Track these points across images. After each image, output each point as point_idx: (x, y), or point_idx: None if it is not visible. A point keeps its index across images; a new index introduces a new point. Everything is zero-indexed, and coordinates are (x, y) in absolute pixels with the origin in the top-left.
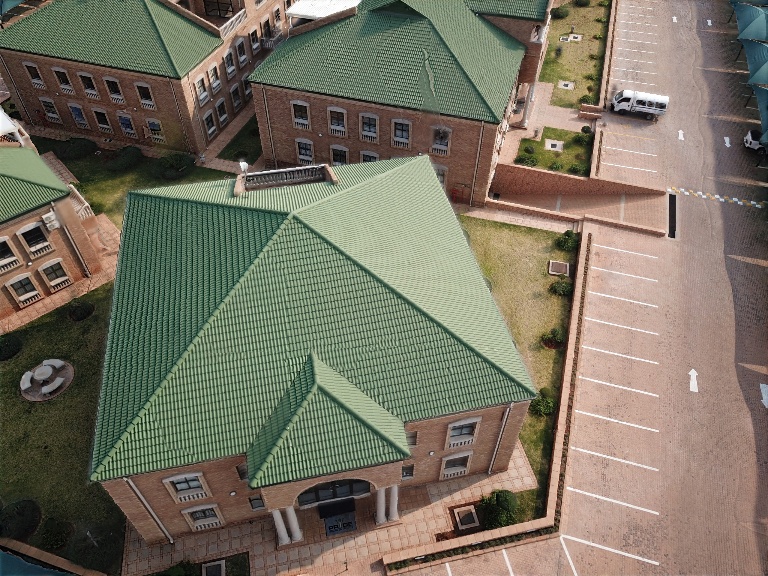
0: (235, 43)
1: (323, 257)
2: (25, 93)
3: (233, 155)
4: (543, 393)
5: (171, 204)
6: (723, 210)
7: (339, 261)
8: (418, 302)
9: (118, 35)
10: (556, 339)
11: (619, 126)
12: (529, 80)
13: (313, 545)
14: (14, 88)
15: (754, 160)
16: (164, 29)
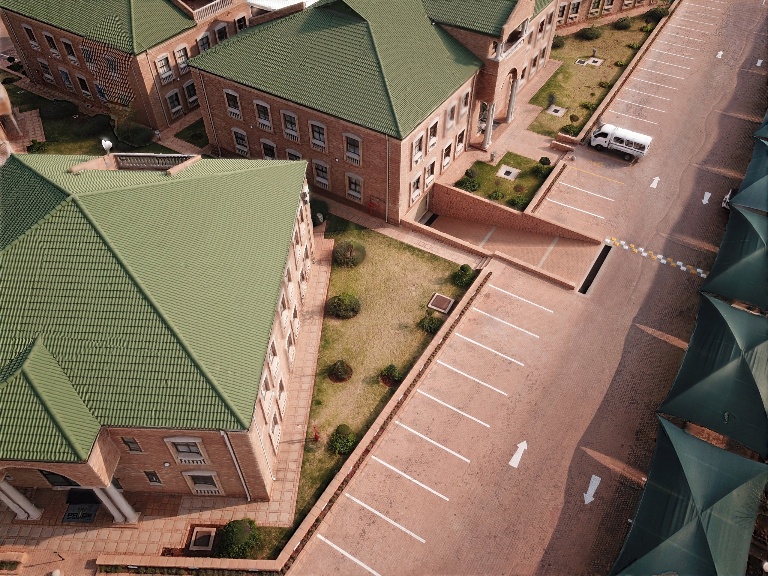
0: (214, 27)
1: (86, 244)
2: (27, 53)
3: (189, 136)
4: (338, 430)
5: (22, 171)
6: (658, 273)
7: (100, 251)
8: (164, 307)
9: (97, 7)
10: (394, 377)
11: (589, 162)
12: (488, 99)
13: (47, 527)
14: (19, 47)
15: None
16: (138, 6)
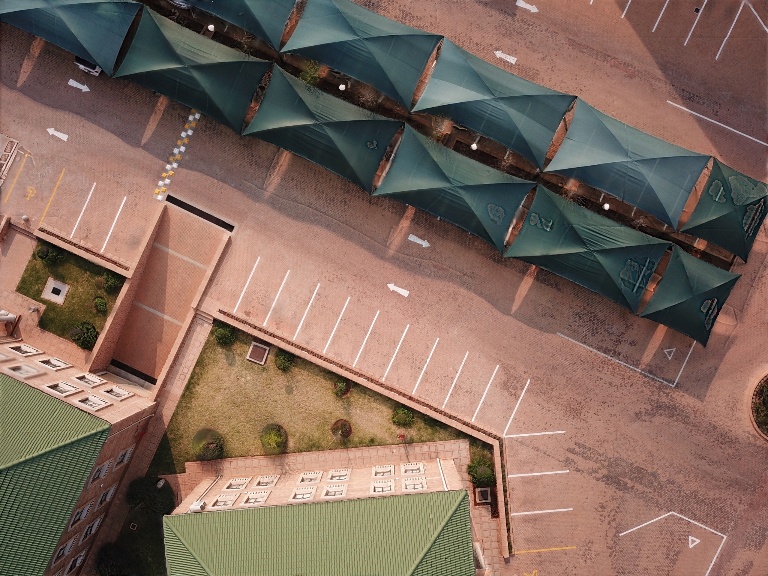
0: None
1: None
2: None
3: None
4: None
5: None
6: (199, 157)
7: None
8: None
9: None
10: None
11: (30, 202)
12: None
13: None
14: None
15: None
16: None
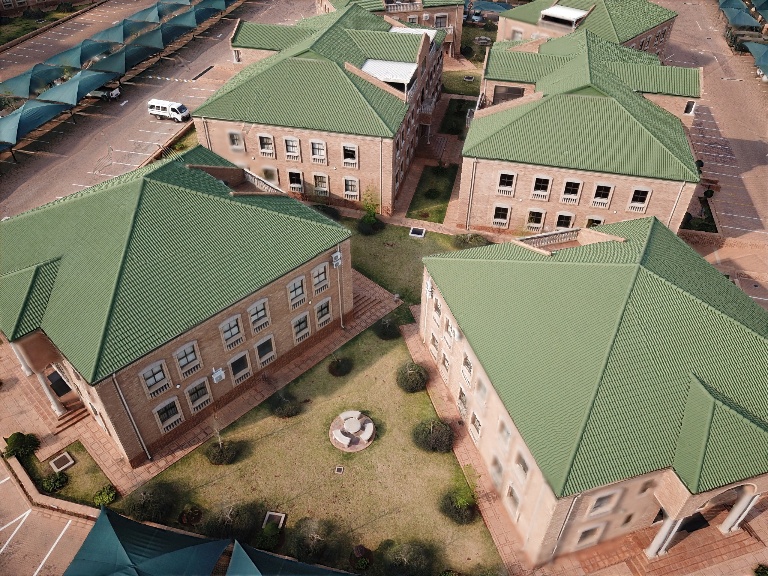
0: None
1: None
2: None
3: (467, 102)
4: None
5: None
6: None
7: None
8: None
9: None
10: None
11: None
12: None
13: None
14: None
15: (121, 93)
16: (523, 42)
